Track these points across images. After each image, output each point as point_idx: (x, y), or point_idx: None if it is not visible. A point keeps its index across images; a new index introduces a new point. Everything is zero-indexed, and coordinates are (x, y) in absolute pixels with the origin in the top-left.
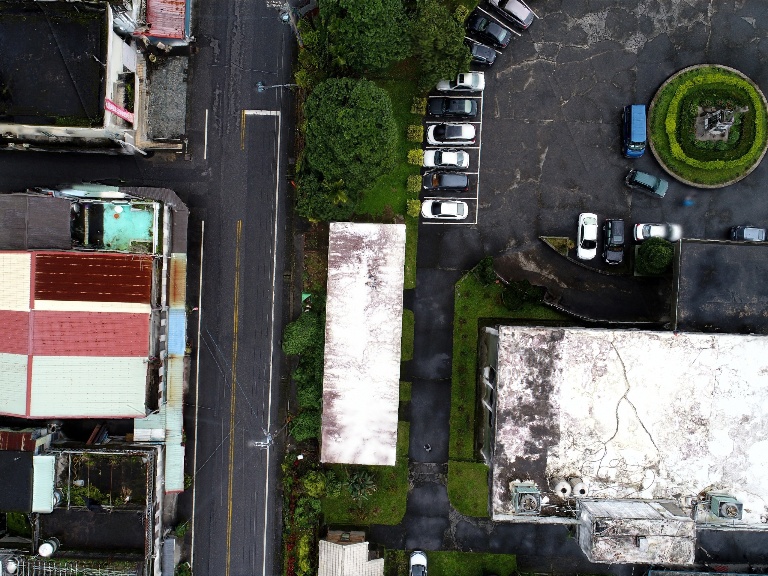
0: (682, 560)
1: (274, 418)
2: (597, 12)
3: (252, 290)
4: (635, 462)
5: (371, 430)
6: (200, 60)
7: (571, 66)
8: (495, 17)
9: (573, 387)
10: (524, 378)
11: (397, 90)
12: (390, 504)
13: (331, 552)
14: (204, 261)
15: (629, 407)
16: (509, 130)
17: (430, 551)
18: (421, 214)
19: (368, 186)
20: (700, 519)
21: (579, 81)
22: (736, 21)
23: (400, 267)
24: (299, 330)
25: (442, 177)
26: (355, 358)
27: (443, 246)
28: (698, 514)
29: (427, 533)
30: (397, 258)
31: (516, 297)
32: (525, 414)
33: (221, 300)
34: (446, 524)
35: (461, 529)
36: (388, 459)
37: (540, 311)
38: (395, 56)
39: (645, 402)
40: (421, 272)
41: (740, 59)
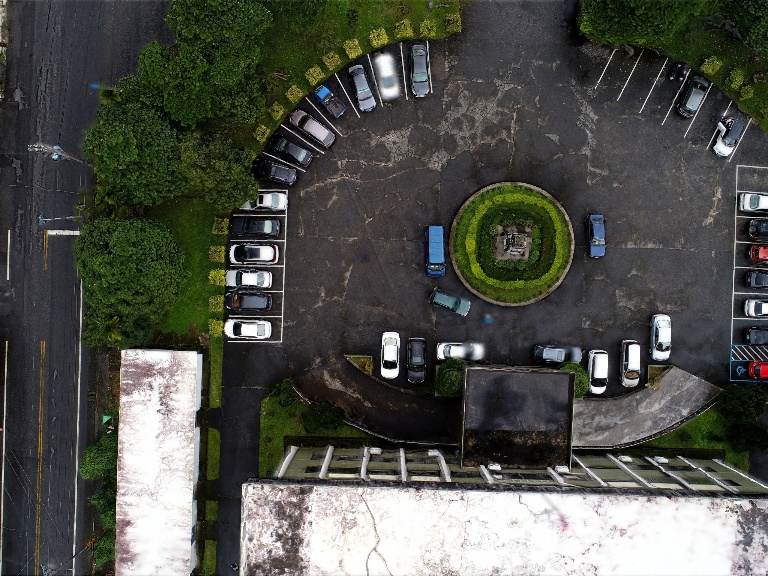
0: None
1: (79, 538)
2: (400, 130)
3: (56, 410)
4: None
5: (164, 558)
6: (2, 180)
7: (375, 184)
8: (298, 135)
9: (323, 540)
10: (274, 531)
11: (201, 208)
12: None
13: None
14: (8, 382)
15: (379, 560)
16: (313, 248)
17: None
18: (224, 334)
19: (152, 318)
20: None
21: (383, 199)
22: (539, 138)
23: (192, 394)
24: (93, 457)
25: (242, 298)
26: (147, 486)
27: (248, 365)
28: None
29: None
30: (189, 385)
31: (315, 420)
32: (275, 567)
33: (25, 421)
34: None
35: None
36: None
37: (346, 429)
38: (169, 193)
39: (395, 554)
40: (226, 391)
41: (543, 176)
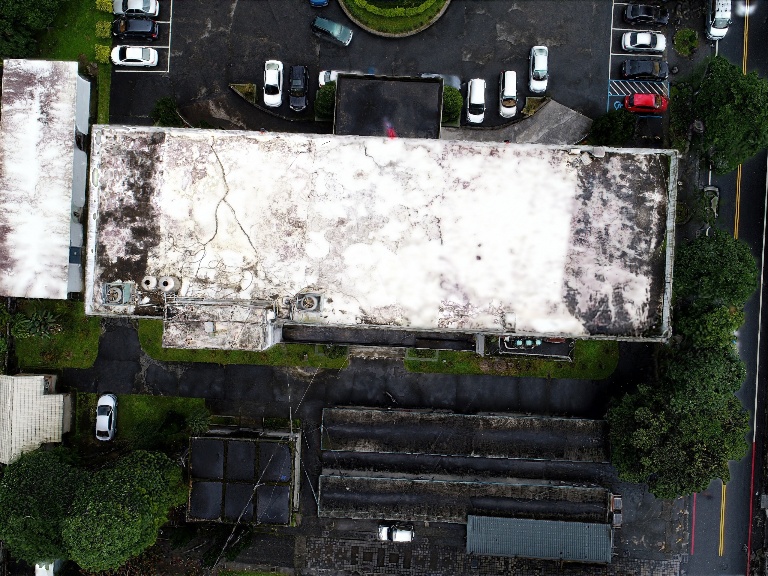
0: (251, 346)
1: None
2: None
3: None
4: (233, 263)
5: (43, 264)
6: None
7: None
8: None
9: (173, 189)
10: (125, 180)
11: None
12: (82, 348)
13: (3, 384)
14: None
15: (228, 209)
16: None
17: (121, 394)
18: (111, 61)
19: (30, 18)
20: (296, 319)
21: None
22: None
23: (72, 104)
24: None
25: (128, 22)
26: (27, 193)
27: (135, 94)
28: (295, 315)
29: (118, 376)
30: (69, 95)
31: None
32: (126, 215)
33: None
34: (137, 368)
35: (151, 373)
36: (59, 293)
37: None
38: None
39: (243, 204)
40: (114, 119)
41: None
